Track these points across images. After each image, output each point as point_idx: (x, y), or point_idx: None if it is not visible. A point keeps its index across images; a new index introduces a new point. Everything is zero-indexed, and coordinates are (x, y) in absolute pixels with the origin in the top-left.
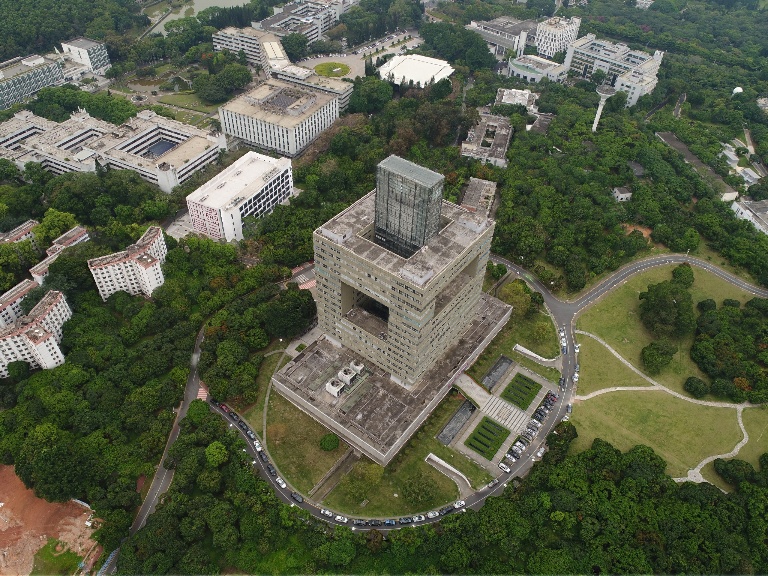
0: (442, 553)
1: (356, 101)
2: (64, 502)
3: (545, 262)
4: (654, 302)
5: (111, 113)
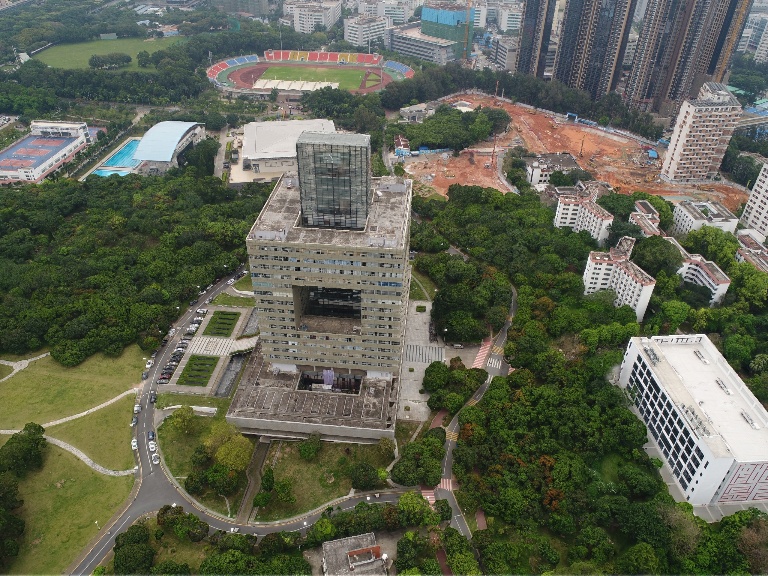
0: None
1: None
2: None
3: (192, 571)
4: None
5: None
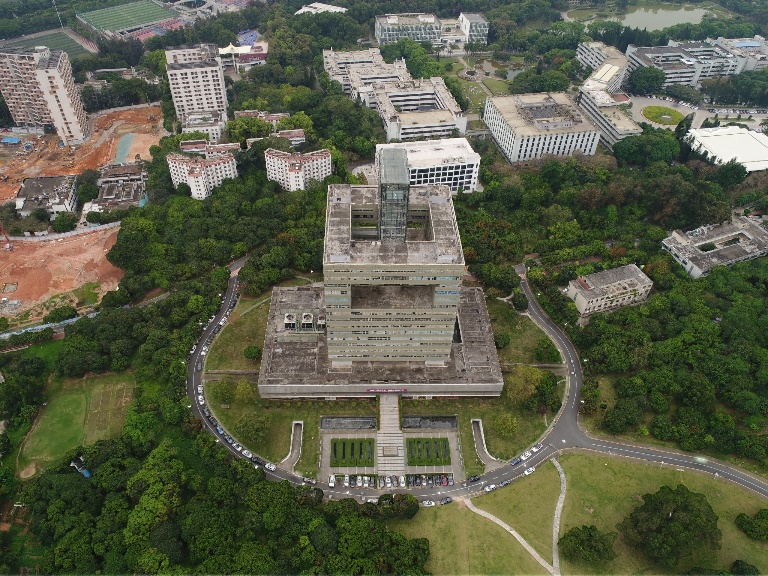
0: (214, 476)
1: (622, 145)
2: (113, 265)
3: None
4: (655, 499)
5: (421, 71)
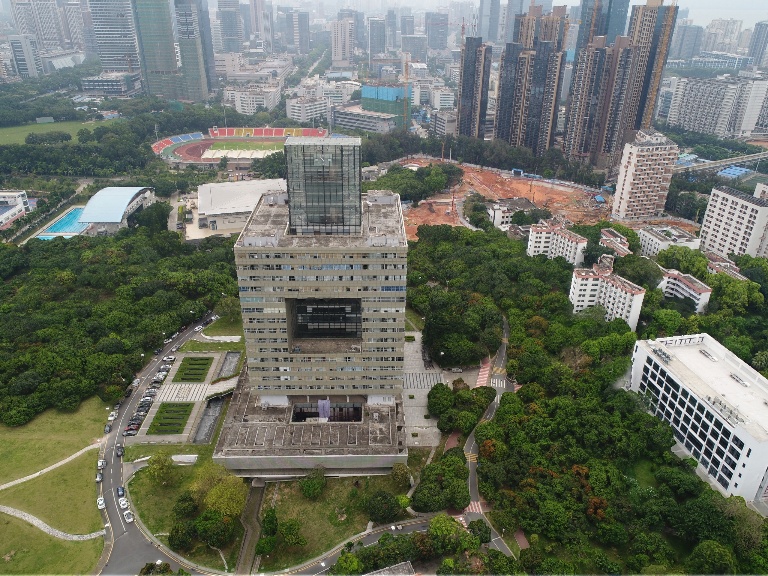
0: None
1: None
2: None
3: None
4: None
5: None
